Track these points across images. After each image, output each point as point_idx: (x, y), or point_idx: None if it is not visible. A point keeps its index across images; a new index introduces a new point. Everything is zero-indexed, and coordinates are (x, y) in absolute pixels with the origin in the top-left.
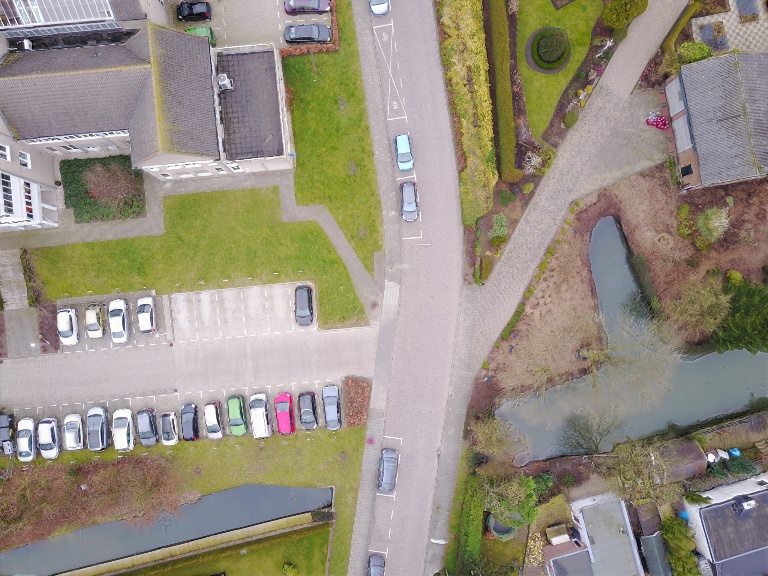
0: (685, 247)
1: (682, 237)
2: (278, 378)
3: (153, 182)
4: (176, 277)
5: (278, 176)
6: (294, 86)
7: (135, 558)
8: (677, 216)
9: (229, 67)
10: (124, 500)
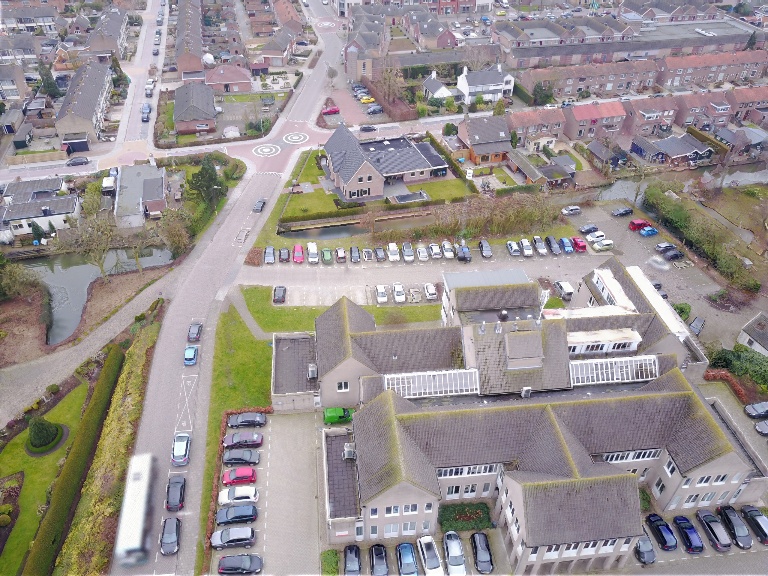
0: (7, 327)
1: (6, 332)
2: (301, 270)
3: None
4: None
5: None
6: (267, 401)
7: (387, 218)
8: (2, 342)
9: (310, 388)
10: None
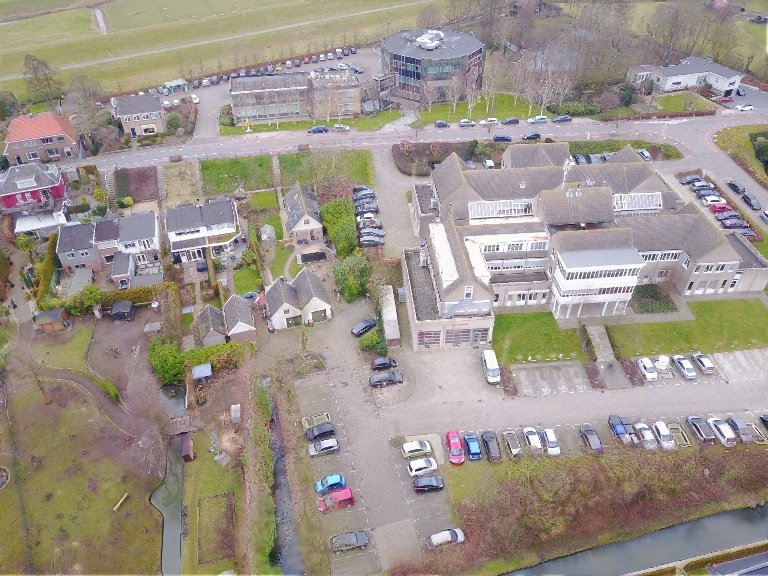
0: None
1: None
2: None
3: (676, 296)
4: (713, 343)
5: (755, 294)
6: None
7: None
8: None
9: None
10: (743, 488)
